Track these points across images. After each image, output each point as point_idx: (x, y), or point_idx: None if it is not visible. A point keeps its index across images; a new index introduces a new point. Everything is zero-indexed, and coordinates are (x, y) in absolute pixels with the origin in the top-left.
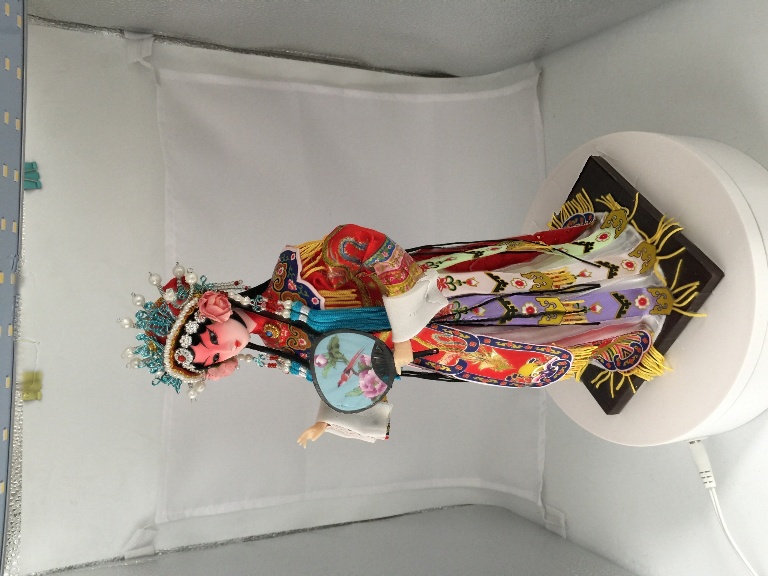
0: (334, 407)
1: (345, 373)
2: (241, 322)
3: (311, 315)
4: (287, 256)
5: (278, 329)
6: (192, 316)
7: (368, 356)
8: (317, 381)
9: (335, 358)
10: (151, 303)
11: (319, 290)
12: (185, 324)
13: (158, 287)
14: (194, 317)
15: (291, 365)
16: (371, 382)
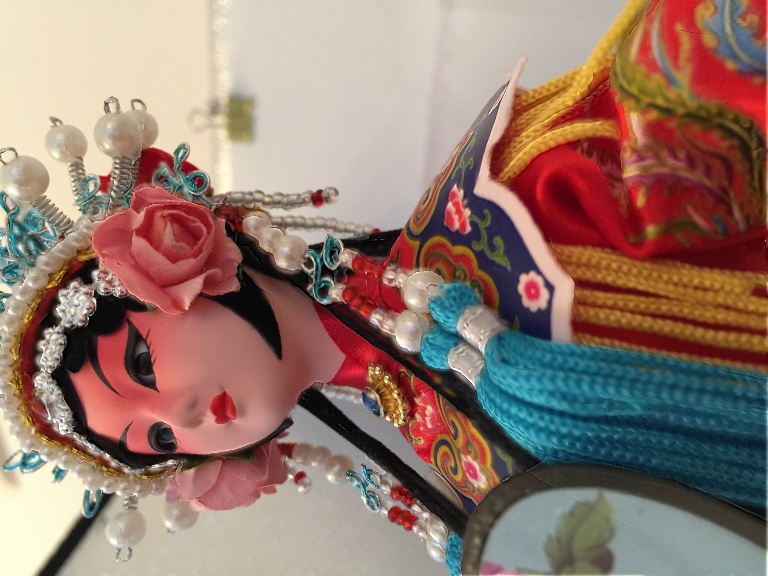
0: None
1: None
2: (263, 330)
3: (492, 355)
4: (487, 109)
5: (400, 392)
6: (91, 267)
7: None
8: None
9: None
10: None
11: (566, 242)
12: (60, 289)
13: (73, 171)
14: (92, 271)
15: (446, 544)
16: None
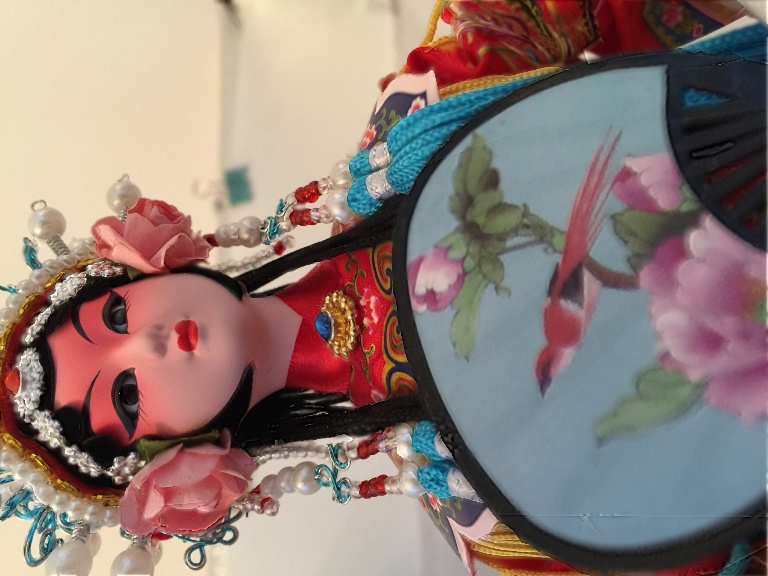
0: (551, 539)
1: (559, 300)
2: (226, 283)
3: None
4: None
5: (347, 298)
6: None
7: (655, 159)
8: (436, 391)
9: (492, 240)
10: None
11: None
12: (57, 283)
13: None
14: (87, 266)
15: None
16: (735, 304)
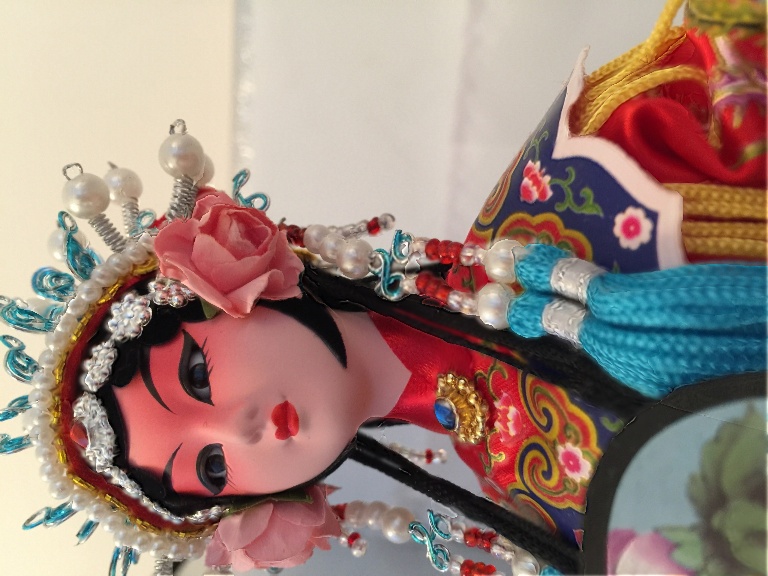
0: None
1: None
2: (326, 337)
3: (598, 289)
4: None
5: (478, 395)
6: (147, 280)
7: None
8: None
9: (747, 575)
10: (96, 255)
11: (659, 181)
12: (113, 302)
13: (127, 211)
14: (148, 282)
15: None
16: None
